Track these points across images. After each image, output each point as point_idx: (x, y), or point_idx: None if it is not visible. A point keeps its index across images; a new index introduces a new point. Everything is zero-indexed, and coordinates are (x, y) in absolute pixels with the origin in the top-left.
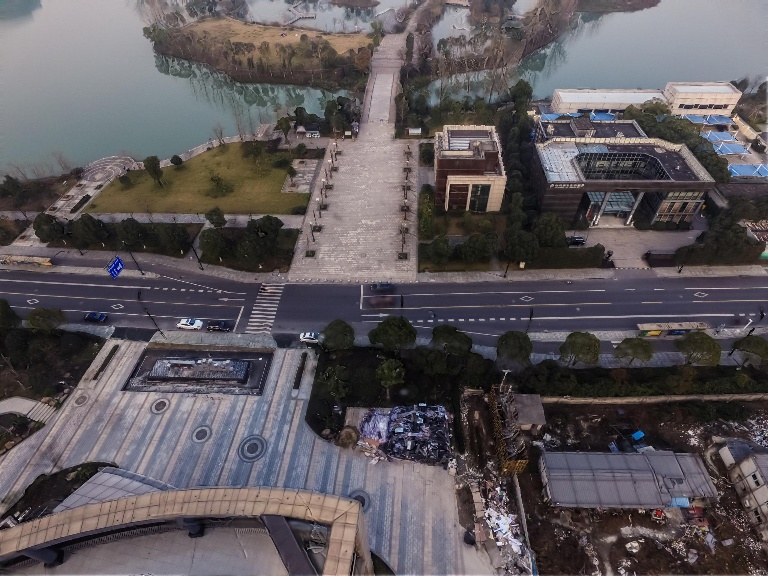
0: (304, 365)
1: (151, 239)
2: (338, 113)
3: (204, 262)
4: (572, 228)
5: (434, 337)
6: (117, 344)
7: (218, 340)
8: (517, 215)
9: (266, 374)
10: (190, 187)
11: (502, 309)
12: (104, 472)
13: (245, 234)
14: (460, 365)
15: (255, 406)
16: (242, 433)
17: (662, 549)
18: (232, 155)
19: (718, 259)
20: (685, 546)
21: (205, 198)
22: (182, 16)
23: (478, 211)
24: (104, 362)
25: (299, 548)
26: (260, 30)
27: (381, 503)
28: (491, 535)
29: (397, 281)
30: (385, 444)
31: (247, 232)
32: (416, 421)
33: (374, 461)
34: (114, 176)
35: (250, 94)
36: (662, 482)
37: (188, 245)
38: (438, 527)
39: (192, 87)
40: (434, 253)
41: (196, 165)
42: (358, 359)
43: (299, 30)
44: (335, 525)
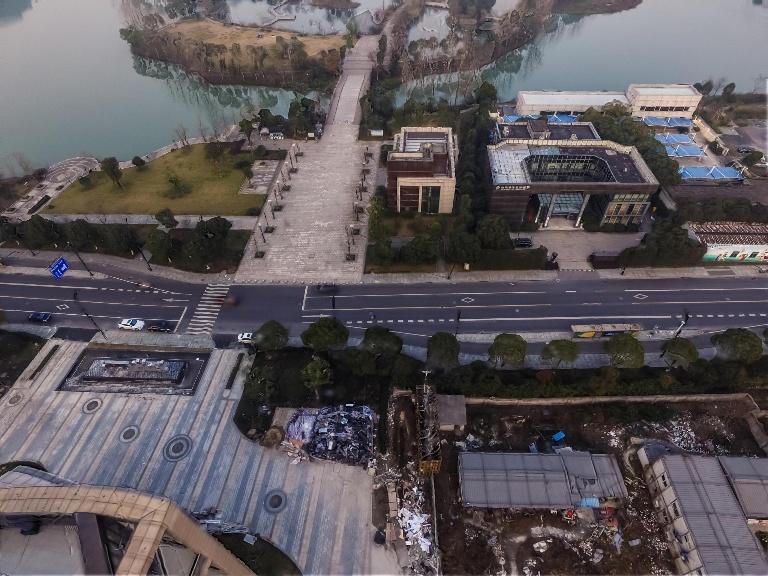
0: (239, 365)
1: (102, 240)
2: (301, 115)
3: (153, 263)
4: (522, 230)
5: (365, 338)
6: (57, 344)
7: (157, 340)
8: (463, 217)
9: (201, 374)
10: (149, 188)
11: (442, 310)
12: (14, 471)
13: (194, 235)
14: (390, 366)
15: (186, 406)
16: (169, 433)
17: (569, 549)
18: (195, 156)
19: (660, 261)
20: (592, 546)
21: (163, 199)
22: (161, 17)
23: (430, 213)
24: (42, 362)
25: (101, 545)
26: (238, 31)
27: (297, 503)
28: (401, 535)
29: (342, 282)
30: (308, 444)
31: (196, 233)
32: (340, 421)
33: (296, 461)
34: (76, 177)
35: (224, 95)
36: (574, 483)
37: (139, 246)
38: (350, 526)
39: (169, 88)
40: (376, 254)
41: (158, 166)
42: (293, 360)
43: (276, 31)
44: (141, 523)
